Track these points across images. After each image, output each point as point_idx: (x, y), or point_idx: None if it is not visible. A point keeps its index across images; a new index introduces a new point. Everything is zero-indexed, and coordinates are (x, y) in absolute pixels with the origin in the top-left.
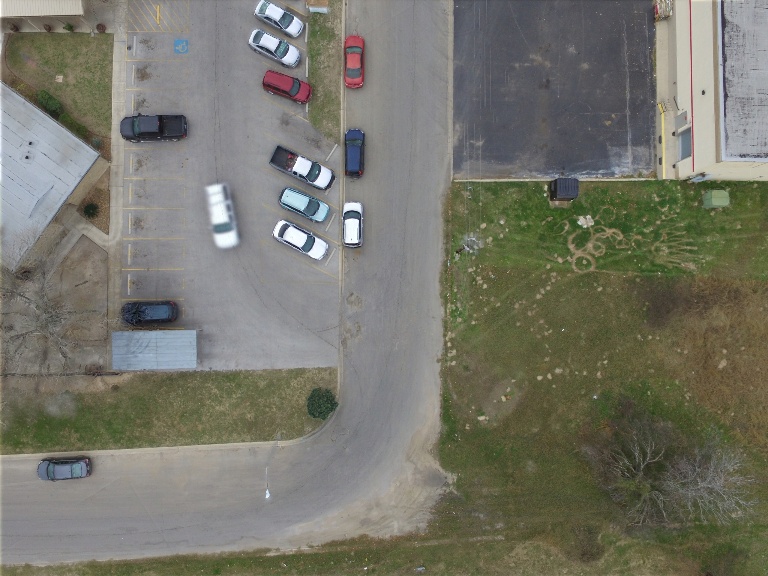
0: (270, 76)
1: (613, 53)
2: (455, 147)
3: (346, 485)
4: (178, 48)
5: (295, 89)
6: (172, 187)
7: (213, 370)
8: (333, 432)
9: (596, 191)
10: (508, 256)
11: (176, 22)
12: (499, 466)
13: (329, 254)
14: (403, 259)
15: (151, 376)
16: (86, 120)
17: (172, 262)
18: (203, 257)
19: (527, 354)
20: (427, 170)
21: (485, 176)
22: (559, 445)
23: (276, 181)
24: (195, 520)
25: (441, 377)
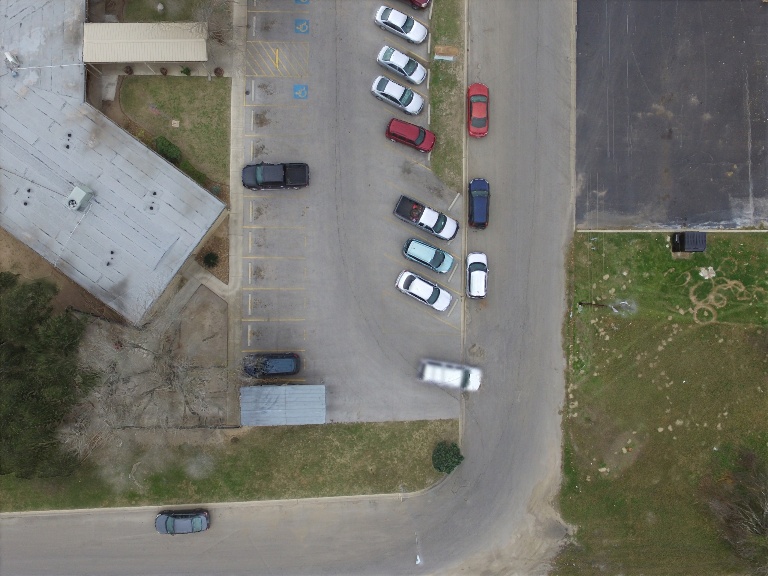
0: (396, 125)
1: (735, 103)
2: (578, 197)
3: (467, 537)
4: (298, 93)
5: (420, 138)
6: (292, 236)
7: (334, 422)
8: (454, 484)
9: (718, 242)
10: (630, 307)
11: (295, 66)
12: (619, 518)
13: (451, 305)
14: (526, 310)
15: (272, 428)
16: (204, 167)
17: (293, 313)
18: (324, 308)
19: (648, 406)
20: (550, 220)
21: (608, 226)
22: (679, 496)
23: (398, 230)
24: (315, 573)
25: (562, 429)
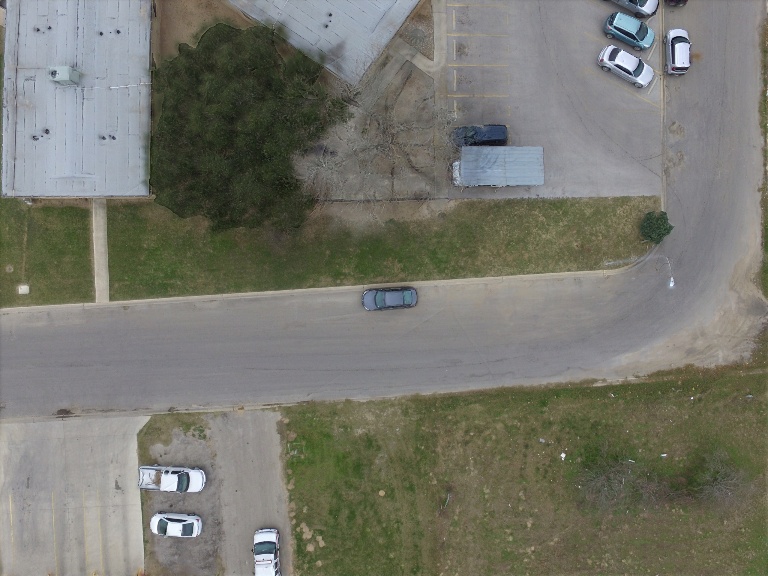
0: None
1: None
2: None
3: (671, 314)
4: None
5: None
6: (495, 14)
7: (540, 197)
8: (657, 261)
9: None
10: None
11: None
12: None
13: (651, 83)
14: (724, 88)
15: (479, 203)
16: None
17: (497, 89)
18: (528, 84)
19: None
20: (744, 1)
21: None
22: None
23: (598, 10)
24: (521, 351)
25: (762, 206)
